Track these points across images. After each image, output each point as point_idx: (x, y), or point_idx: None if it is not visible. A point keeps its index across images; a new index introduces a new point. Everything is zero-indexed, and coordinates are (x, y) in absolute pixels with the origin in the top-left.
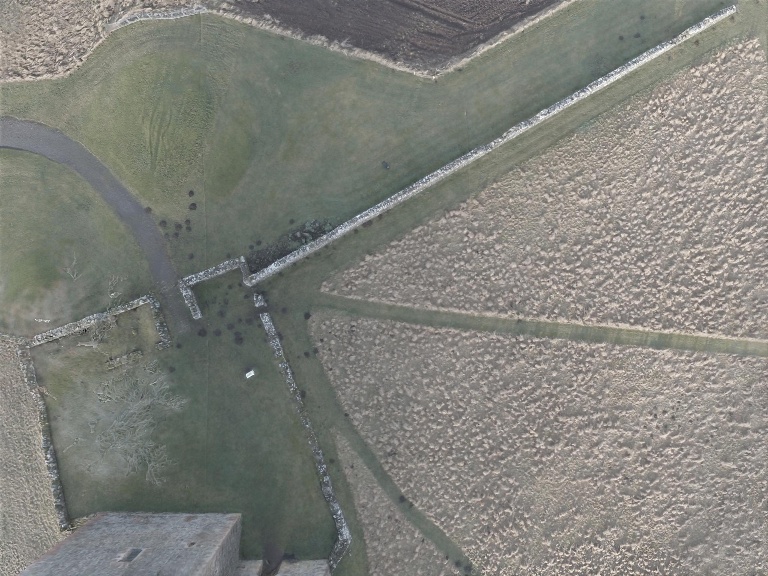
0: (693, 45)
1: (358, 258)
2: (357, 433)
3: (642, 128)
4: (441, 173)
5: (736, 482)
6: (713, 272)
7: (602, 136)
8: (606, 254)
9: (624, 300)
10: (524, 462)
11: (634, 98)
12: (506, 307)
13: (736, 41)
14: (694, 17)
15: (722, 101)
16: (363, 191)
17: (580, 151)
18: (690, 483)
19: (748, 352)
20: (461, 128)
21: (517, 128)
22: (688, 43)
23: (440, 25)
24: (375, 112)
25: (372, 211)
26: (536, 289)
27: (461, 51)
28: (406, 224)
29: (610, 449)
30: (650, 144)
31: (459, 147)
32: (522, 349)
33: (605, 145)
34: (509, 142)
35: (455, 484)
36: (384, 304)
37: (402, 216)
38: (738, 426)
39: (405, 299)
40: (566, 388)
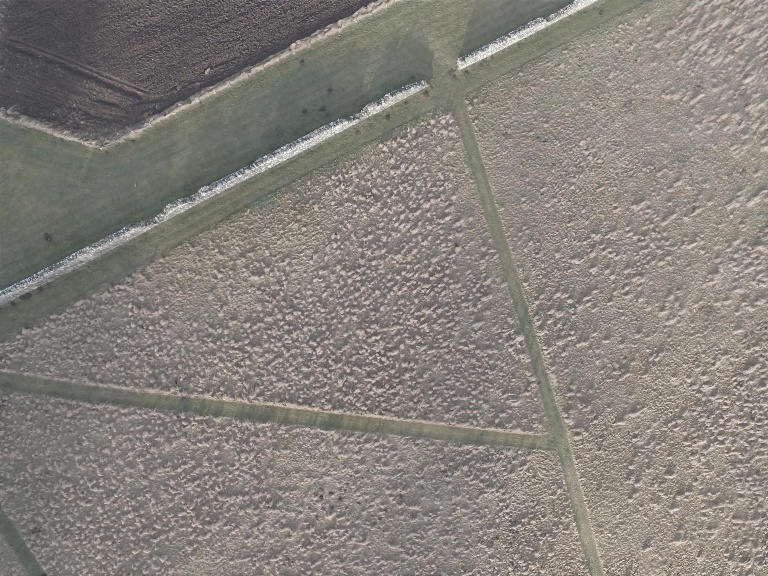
0: (383, 119)
1: (15, 331)
2: (1, 509)
3: (323, 204)
4: (89, 250)
5: (404, 565)
6: (388, 353)
7: (278, 212)
8: (277, 332)
9: (294, 379)
10: (179, 541)
11: (317, 173)
12: (169, 384)
13: (429, 116)
14: (382, 91)
15: (410, 178)
16: (22, 263)
17: (253, 227)
18: (354, 565)
19: (423, 434)
20: (129, 200)
21: (172, 205)
22: (378, 117)
23: (113, 94)
24: (40, 182)
25: (14, 287)
26: (202, 366)
27: (135, 121)
28: (68, 297)
29: (271, 530)
30: (331, 220)
31: (125, 220)
32: (184, 427)
33: (280, 221)
34: (178, 216)
35: (101, 563)
36: (40, 378)
37: (64, 289)
38: (408, 509)
39: (62, 374)
40: (228, 467)
